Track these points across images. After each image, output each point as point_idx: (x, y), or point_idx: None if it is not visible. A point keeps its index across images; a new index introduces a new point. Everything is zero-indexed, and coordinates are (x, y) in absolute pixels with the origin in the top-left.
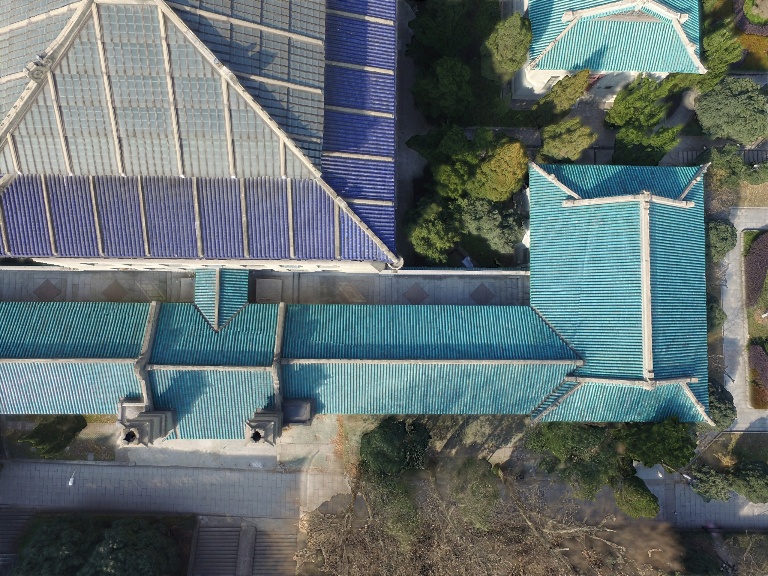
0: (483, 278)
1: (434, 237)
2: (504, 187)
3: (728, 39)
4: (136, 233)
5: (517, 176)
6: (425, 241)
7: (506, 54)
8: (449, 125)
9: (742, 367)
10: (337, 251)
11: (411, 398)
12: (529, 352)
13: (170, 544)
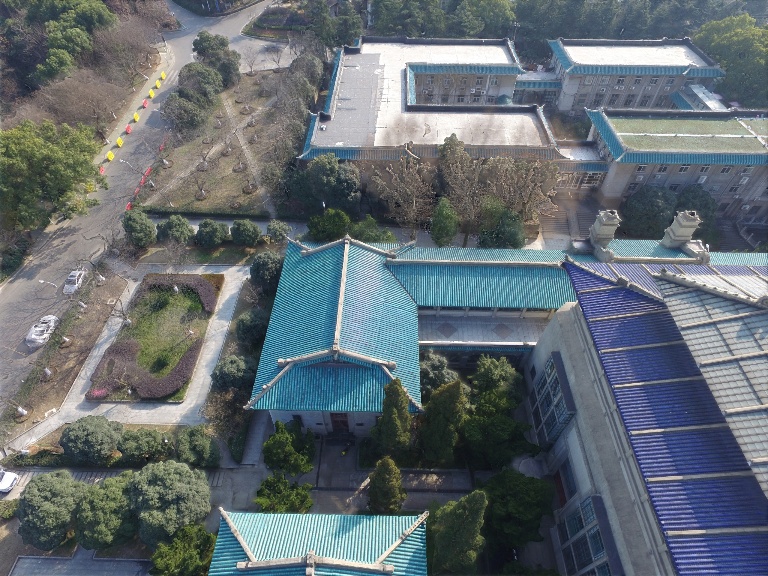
0: None
1: None
2: None
3: (169, 567)
4: (765, 275)
5: None
6: None
7: None
8: (505, 457)
9: (222, 302)
10: None
11: None
12: (424, 270)
13: (625, 224)
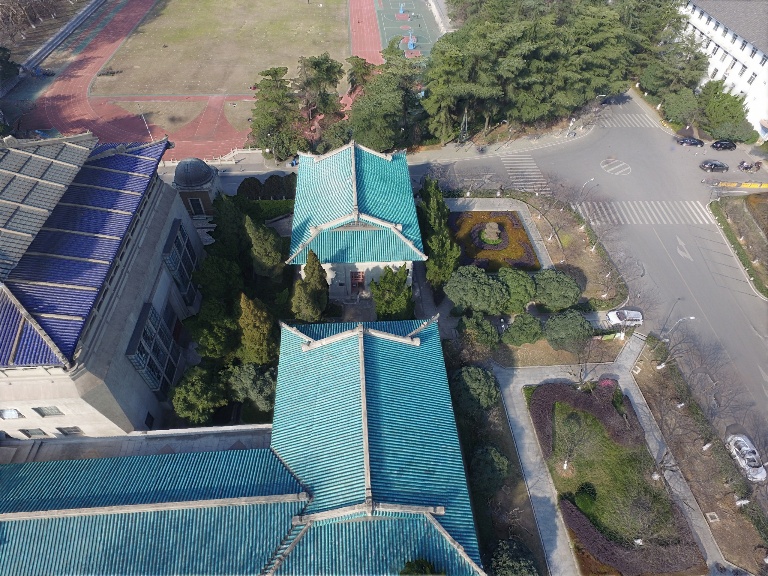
0: (240, 435)
1: (190, 394)
2: (254, 342)
3: (447, 241)
4: None
5: (263, 331)
6: (185, 402)
7: (260, 251)
8: None
9: (561, 531)
10: (11, 357)
11: (102, 568)
12: (252, 492)
13: None
